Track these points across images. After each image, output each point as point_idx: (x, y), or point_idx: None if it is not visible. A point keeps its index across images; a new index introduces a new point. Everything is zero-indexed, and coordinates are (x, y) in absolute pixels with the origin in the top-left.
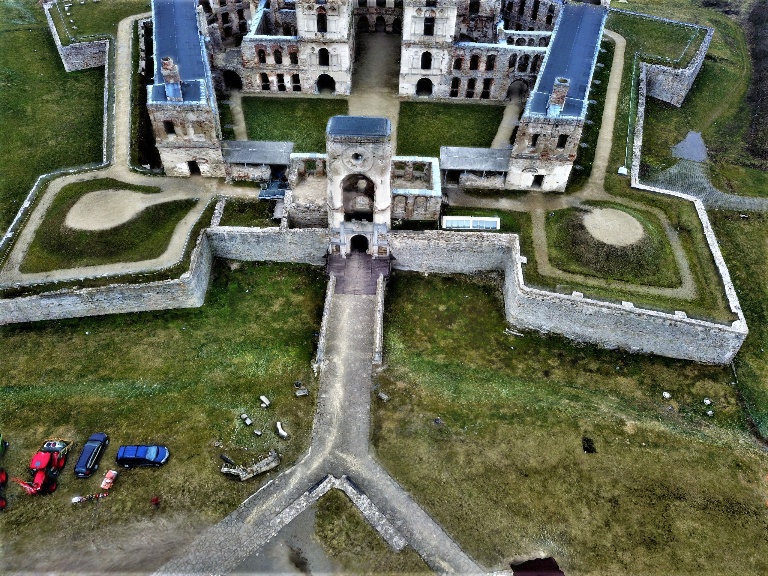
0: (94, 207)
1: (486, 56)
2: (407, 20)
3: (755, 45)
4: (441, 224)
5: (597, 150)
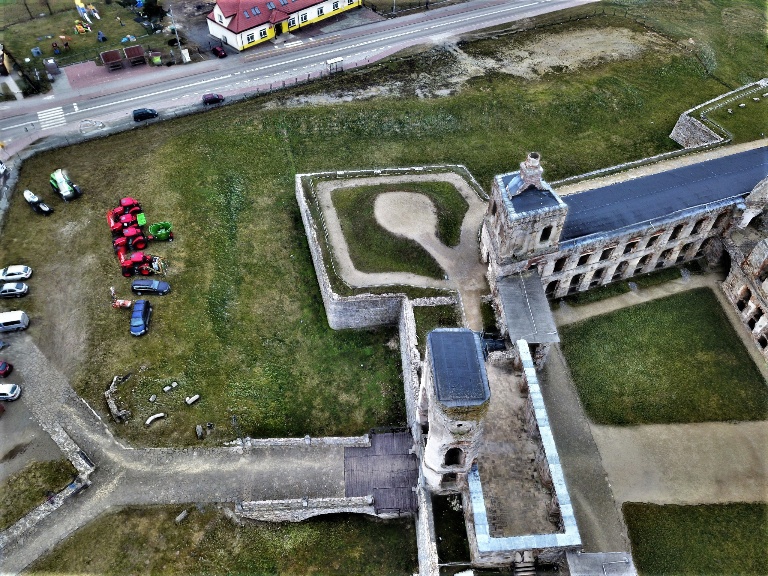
0: (406, 205)
1: None
2: None
3: None
4: (461, 571)
5: None
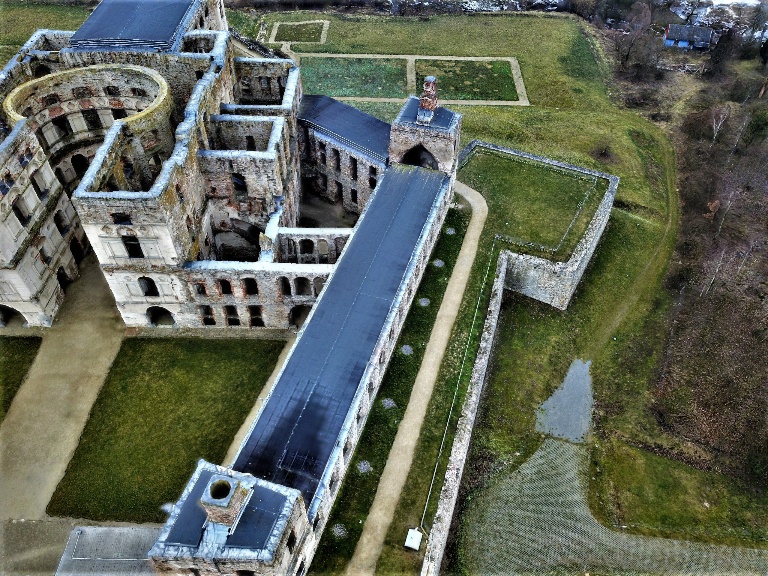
0: None
1: (239, 280)
2: (94, 240)
3: (685, 180)
4: None
5: (382, 480)
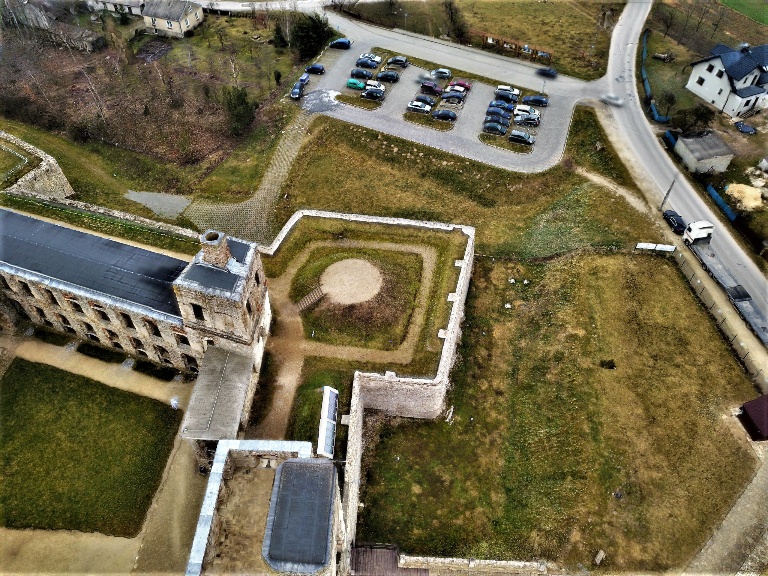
0: None
1: None
2: None
3: None
4: None
5: None
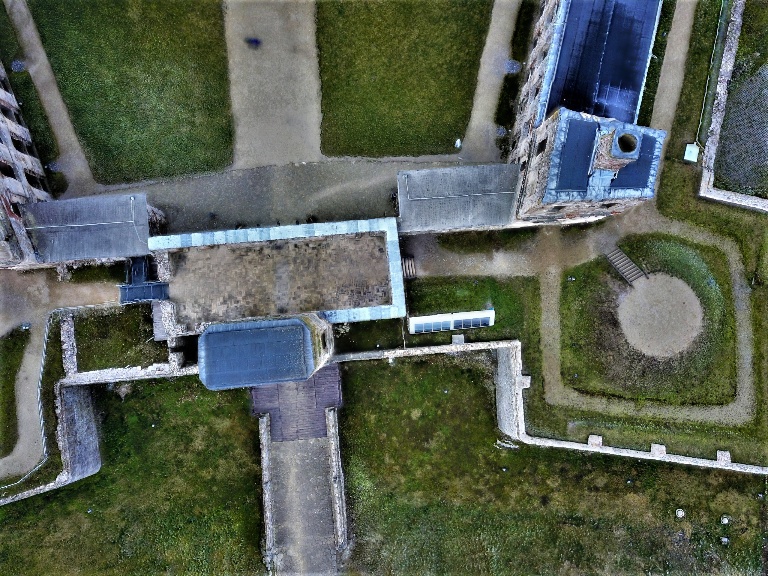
0: None
1: None
2: None
3: None
4: (407, 327)
5: (657, 99)
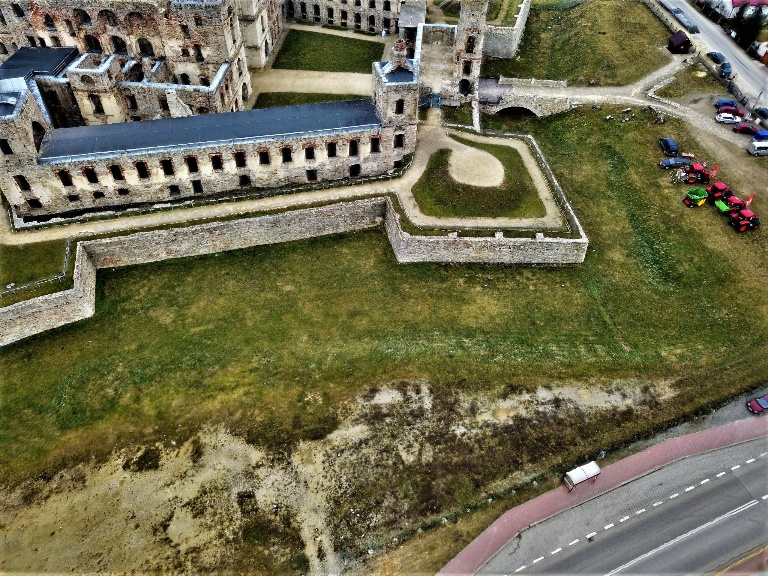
0: (475, 173)
1: None
2: None
3: None
4: None
5: None
